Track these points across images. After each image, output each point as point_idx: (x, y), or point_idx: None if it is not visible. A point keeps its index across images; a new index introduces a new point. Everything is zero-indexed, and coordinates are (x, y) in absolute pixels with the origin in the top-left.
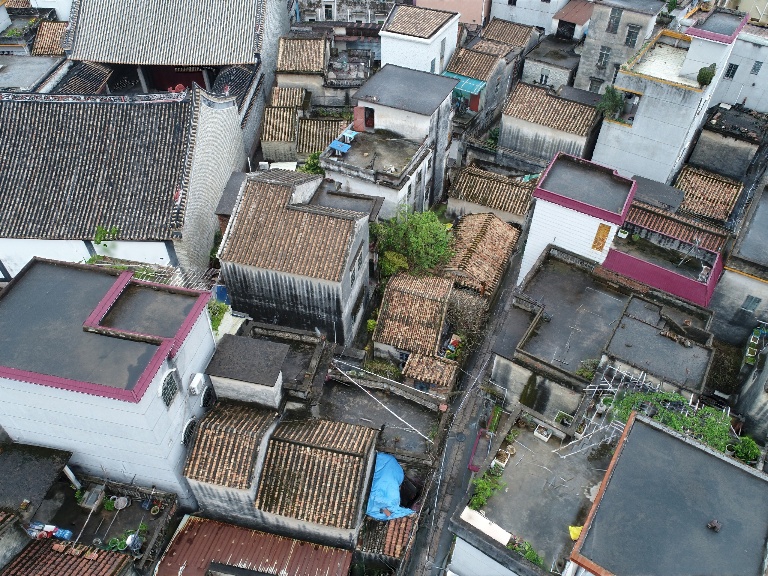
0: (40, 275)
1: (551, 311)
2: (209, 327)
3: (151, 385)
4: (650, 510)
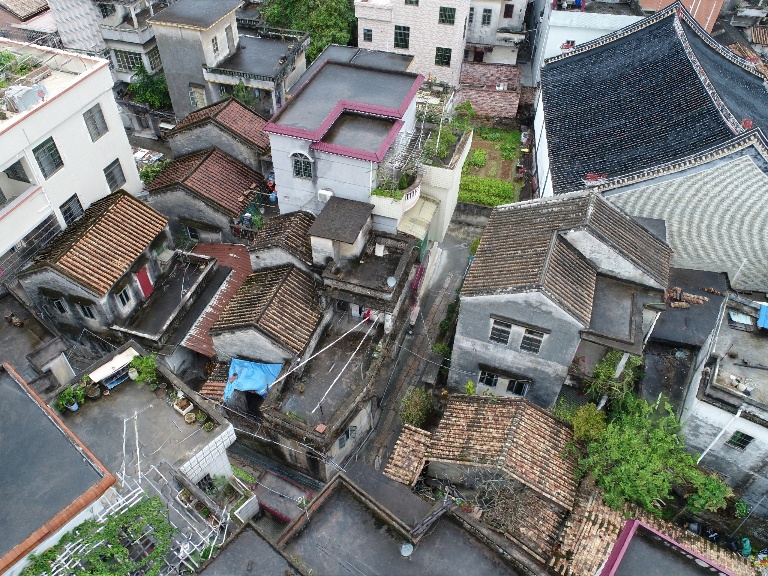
0: (403, 81)
1: (423, 564)
2: (370, 186)
3: (286, 141)
4: (0, 448)
